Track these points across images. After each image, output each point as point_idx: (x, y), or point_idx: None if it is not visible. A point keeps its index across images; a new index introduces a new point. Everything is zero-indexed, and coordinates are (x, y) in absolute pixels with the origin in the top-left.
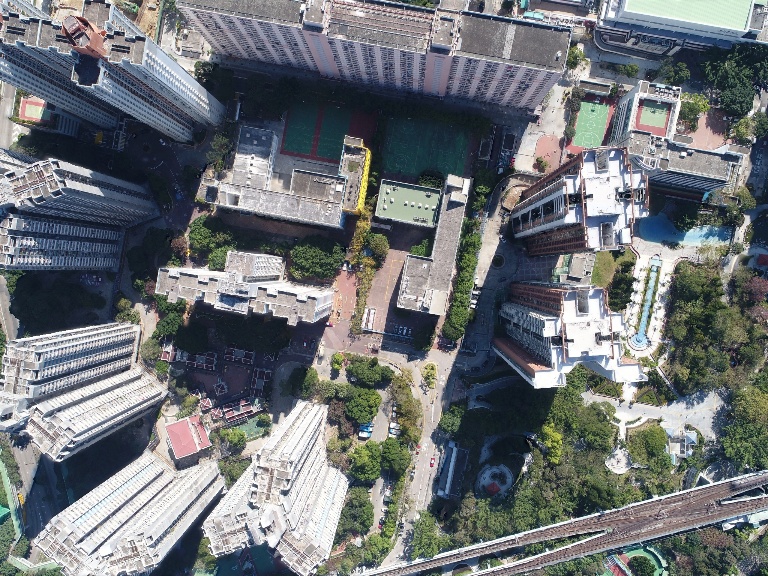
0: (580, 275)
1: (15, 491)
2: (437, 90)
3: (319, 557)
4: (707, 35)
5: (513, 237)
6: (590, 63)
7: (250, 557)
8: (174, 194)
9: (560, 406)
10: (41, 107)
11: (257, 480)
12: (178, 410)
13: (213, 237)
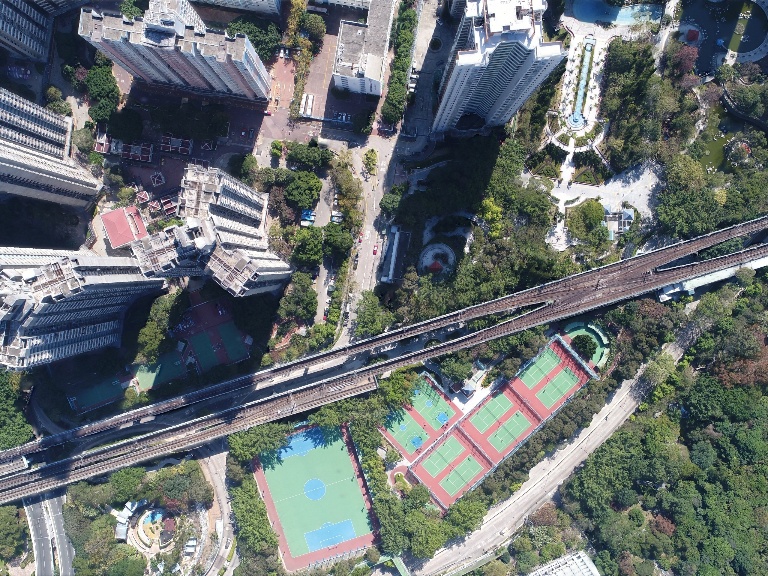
0: None
1: None
2: None
3: (251, 272)
4: None
5: (449, 15)
6: None
7: (193, 353)
8: None
9: (499, 180)
10: None
11: (185, 195)
12: None
13: None
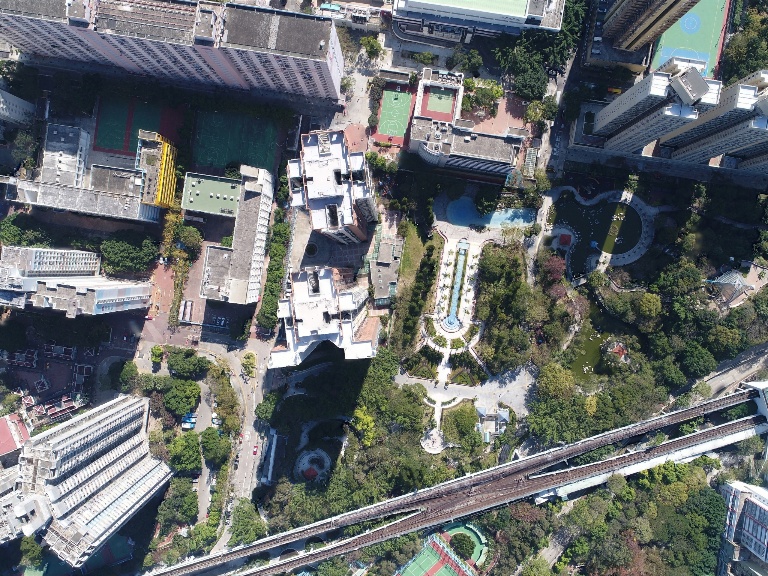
0: (388, 260)
1: None
2: (237, 83)
3: (87, 544)
4: (494, 22)
5: None
6: (392, 53)
7: None
8: None
9: (371, 389)
10: None
11: (22, 471)
12: None
13: (24, 235)
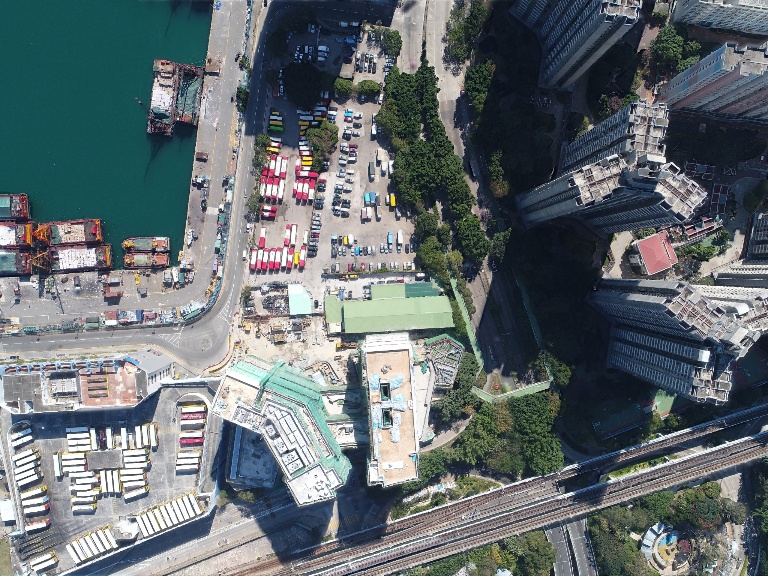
0: None
1: None
2: None
3: None
4: None
5: None
6: None
7: None
8: None
9: None
10: None
11: None
12: None
13: (681, 47)
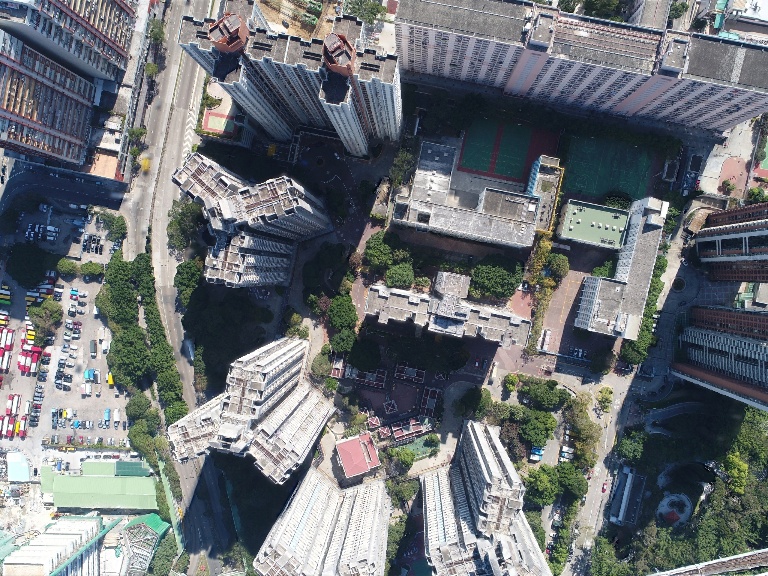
0: (767, 301)
1: (176, 505)
2: (628, 110)
3: None
4: None
5: (699, 261)
6: None
7: None
8: (347, 209)
9: (746, 435)
10: (224, 119)
11: (487, 509)
12: (343, 427)
13: (391, 254)
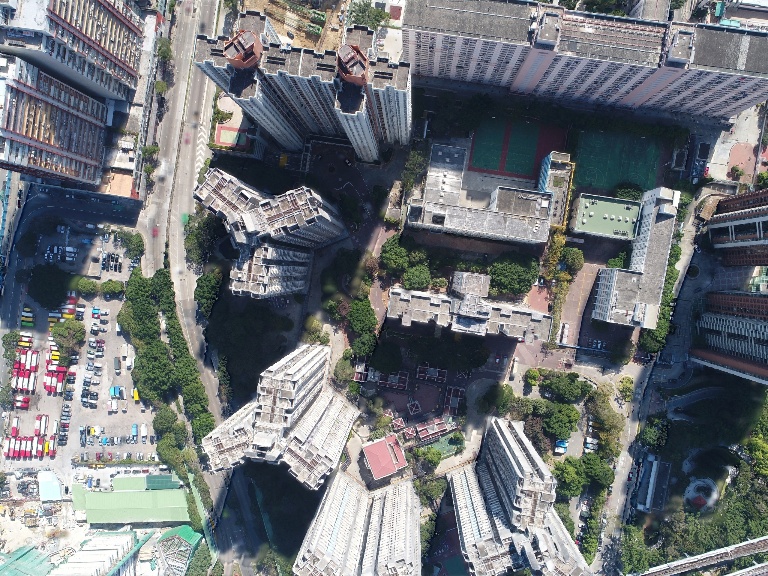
0: None
1: (208, 516)
2: (634, 102)
3: None
4: None
5: (712, 247)
6: None
7: None
8: (361, 214)
9: None
10: (236, 132)
11: (520, 503)
12: (368, 430)
13: (407, 256)
